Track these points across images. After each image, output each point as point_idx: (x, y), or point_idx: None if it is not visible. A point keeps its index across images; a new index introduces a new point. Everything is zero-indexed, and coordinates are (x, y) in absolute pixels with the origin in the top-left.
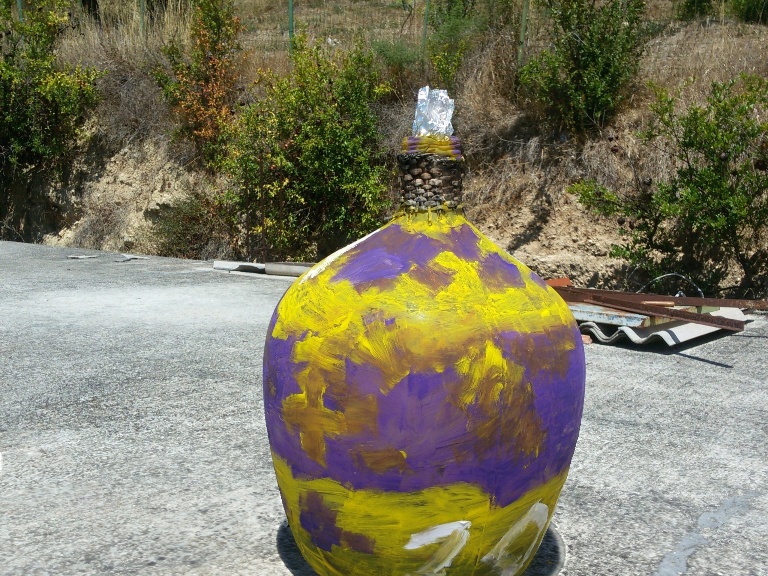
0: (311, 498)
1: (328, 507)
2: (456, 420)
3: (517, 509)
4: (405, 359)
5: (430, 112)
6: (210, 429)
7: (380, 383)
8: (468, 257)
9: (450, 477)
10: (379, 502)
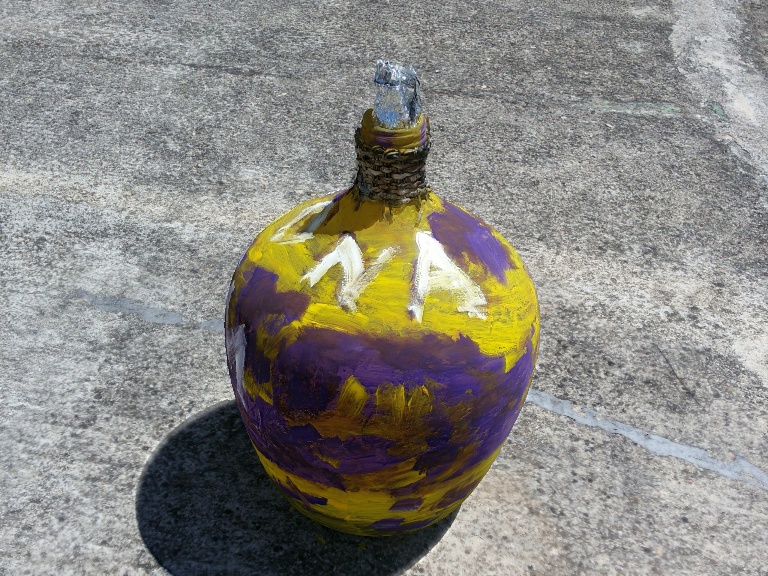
0: None
1: None
2: None
3: None
4: None
5: None
6: None
7: None
8: None
9: None
10: None
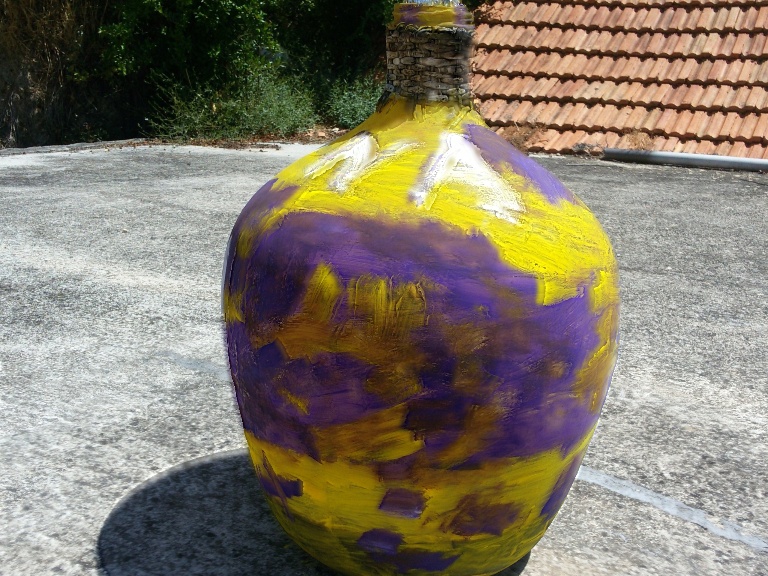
0: None
1: None
2: None
3: None
4: None
5: None
6: None
7: None
8: None
9: None
10: None
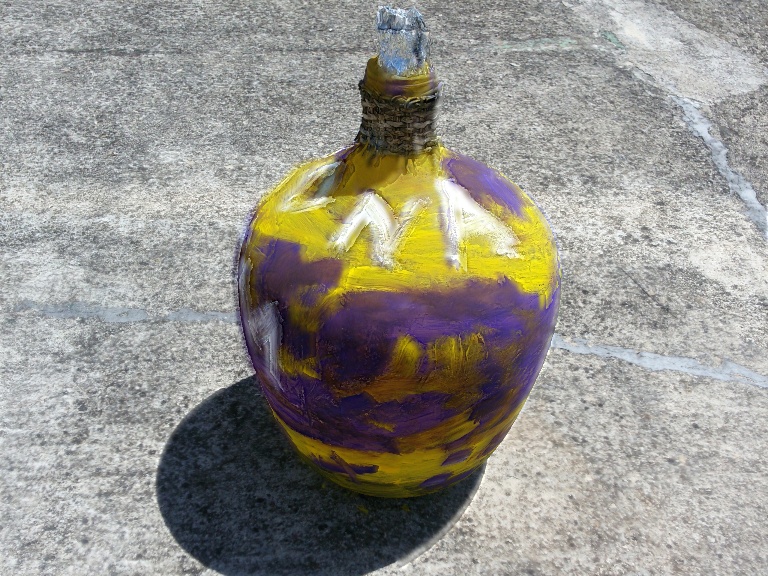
0: None
1: None
2: None
3: None
4: None
5: None
6: None
7: None
8: None
9: None
10: None
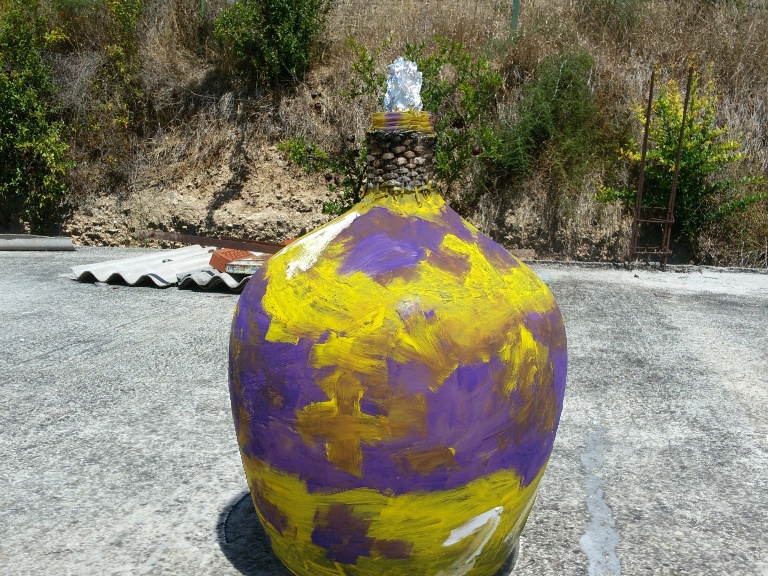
0: (335, 512)
1: (359, 518)
2: (501, 408)
3: (533, 486)
4: (452, 352)
5: (402, 85)
6: (38, 445)
7: (428, 380)
8: (467, 239)
9: (492, 466)
10: (422, 504)
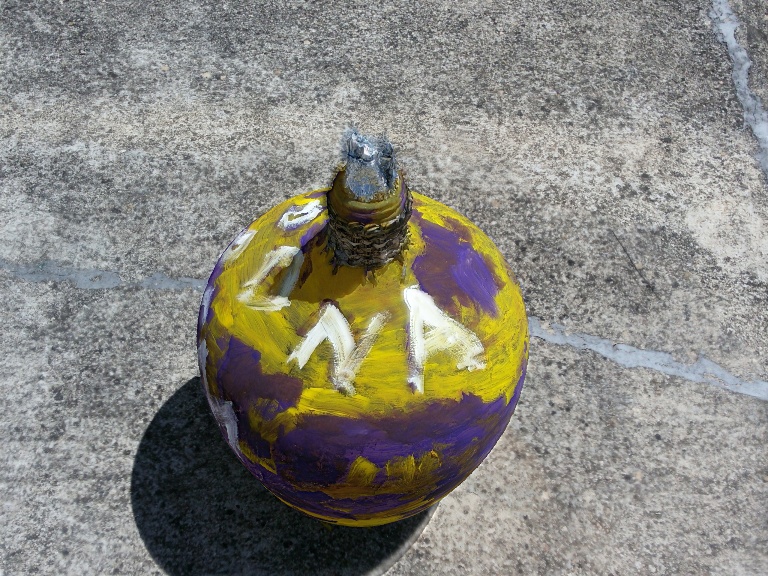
0: None
1: None
2: None
3: None
4: None
5: None
6: None
7: None
8: None
9: None
10: None
